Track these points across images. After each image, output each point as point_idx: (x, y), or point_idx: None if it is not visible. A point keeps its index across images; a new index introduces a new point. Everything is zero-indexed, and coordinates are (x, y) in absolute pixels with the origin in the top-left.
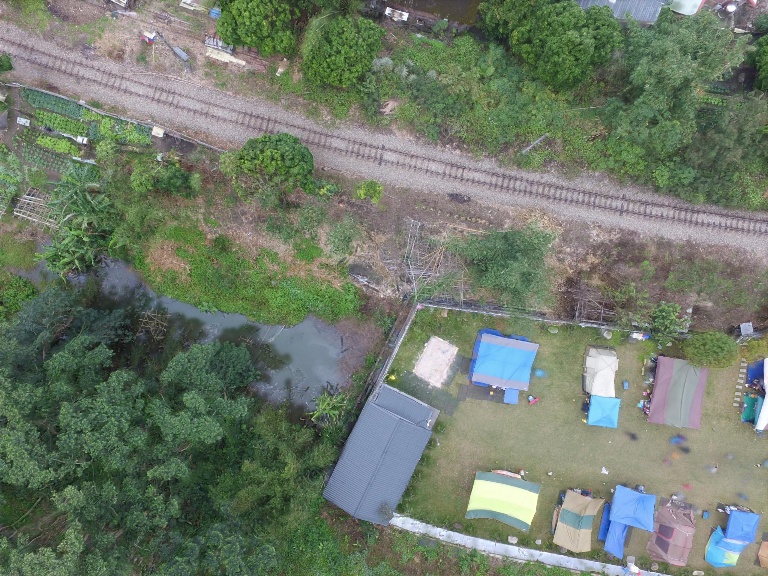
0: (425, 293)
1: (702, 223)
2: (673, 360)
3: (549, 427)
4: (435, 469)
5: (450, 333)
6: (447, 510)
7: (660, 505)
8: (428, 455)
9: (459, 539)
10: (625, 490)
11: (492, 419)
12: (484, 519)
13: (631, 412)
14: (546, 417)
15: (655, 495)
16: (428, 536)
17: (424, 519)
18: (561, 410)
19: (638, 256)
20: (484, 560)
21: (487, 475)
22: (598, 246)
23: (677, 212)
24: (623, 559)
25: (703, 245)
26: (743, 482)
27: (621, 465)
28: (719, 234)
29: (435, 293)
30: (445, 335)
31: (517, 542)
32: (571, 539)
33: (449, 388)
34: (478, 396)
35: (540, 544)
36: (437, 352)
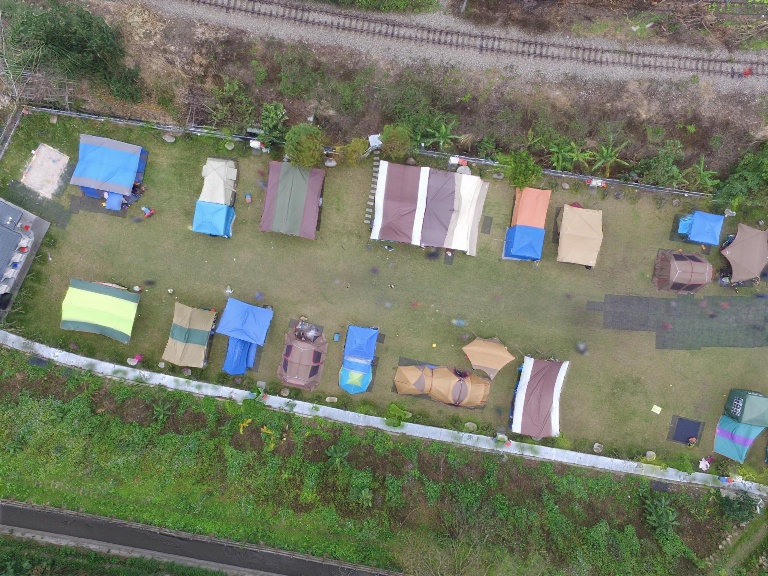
0: (27, 95)
1: (312, 21)
2: (280, 164)
3: (169, 243)
4: (48, 286)
5: (60, 141)
6: (62, 330)
7: (290, 327)
8: (39, 270)
9: (75, 360)
10: (236, 303)
11: (108, 233)
12: (102, 340)
13: (256, 228)
14: (166, 232)
15: (284, 316)
16: (41, 356)
17: (36, 338)
18: (182, 225)
19: (244, 54)
20: (98, 381)
21: (87, 285)
22: (201, 43)
23: (287, 10)
24: (250, 383)
25: (316, 46)
26: (376, 303)
27: (247, 284)
28: (331, 34)
29: (37, 95)
30: (55, 143)
31: (139, 365)
32: (176, 352)
33: (61, 199)
34: (92, 208)
35: (164, 367)
36: (48, 161)
